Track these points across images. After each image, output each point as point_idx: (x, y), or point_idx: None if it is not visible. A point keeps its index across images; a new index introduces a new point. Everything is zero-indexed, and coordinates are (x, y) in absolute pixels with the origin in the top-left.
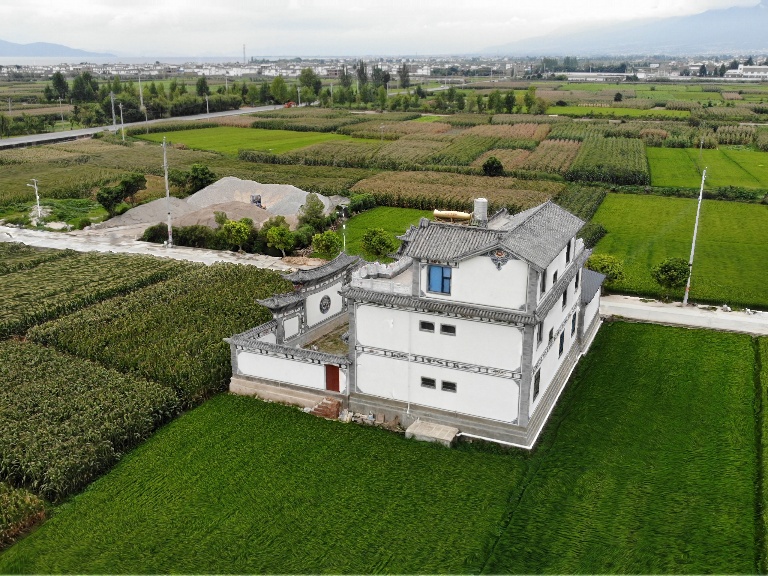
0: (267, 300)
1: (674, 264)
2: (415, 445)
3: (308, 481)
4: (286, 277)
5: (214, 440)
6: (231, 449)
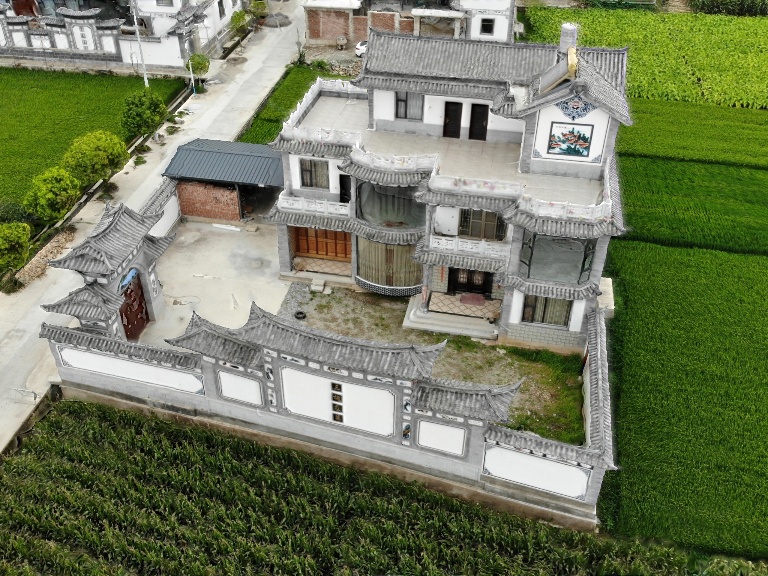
0: (497, 405)
1: (156, 97)
2: (632, 303)
3: (761, 367)
4: (429, 372)
5: (759, 479)
6: (764, 452)
